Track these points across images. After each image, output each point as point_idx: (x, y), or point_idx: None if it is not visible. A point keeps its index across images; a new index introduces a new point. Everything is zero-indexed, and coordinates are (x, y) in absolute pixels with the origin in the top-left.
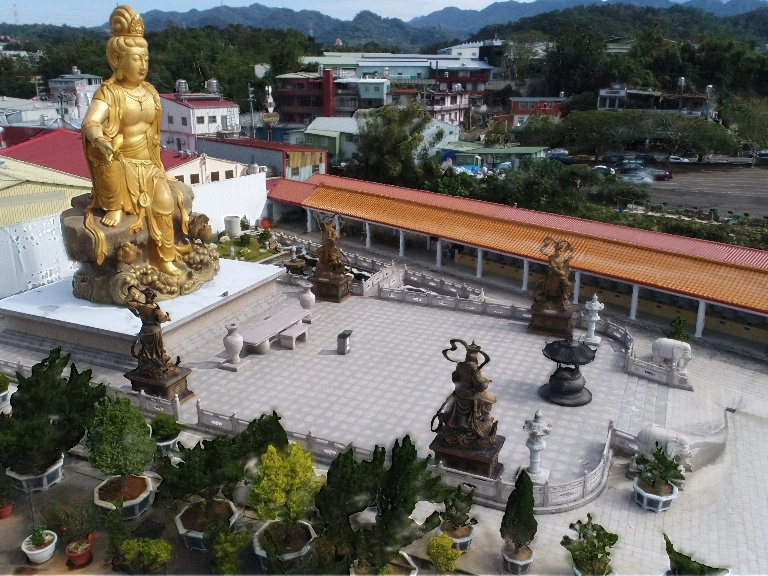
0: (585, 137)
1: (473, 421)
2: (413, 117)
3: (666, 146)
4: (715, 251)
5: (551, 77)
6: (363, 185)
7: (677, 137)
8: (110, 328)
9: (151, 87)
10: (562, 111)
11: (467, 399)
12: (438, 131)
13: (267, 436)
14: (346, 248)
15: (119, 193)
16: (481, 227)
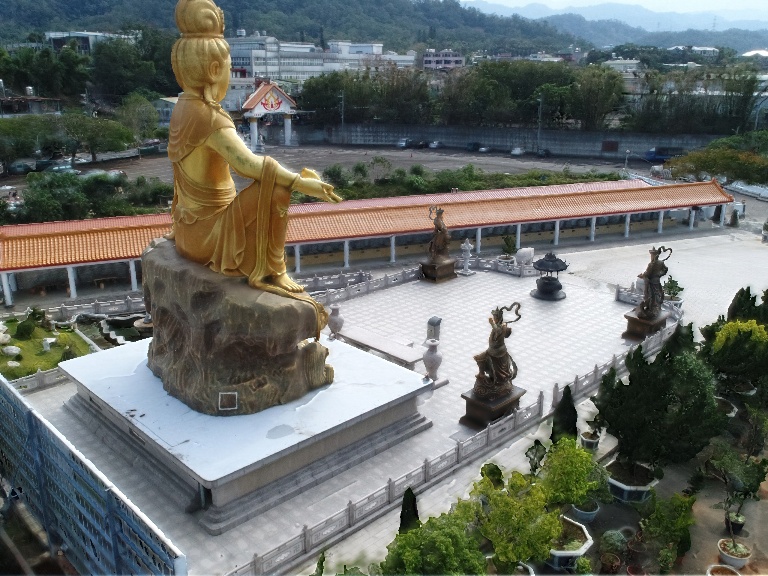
0: (2, 149)
1: (662, 295)
2: None
3: (70, 149)
4: (425, 201)
5: None
6: (10, 231)
7: (77, 139)
8: (396, 395)
9: None
10: None
11: None
12: None
13: None
14: (118, 299)
15: None
16: None
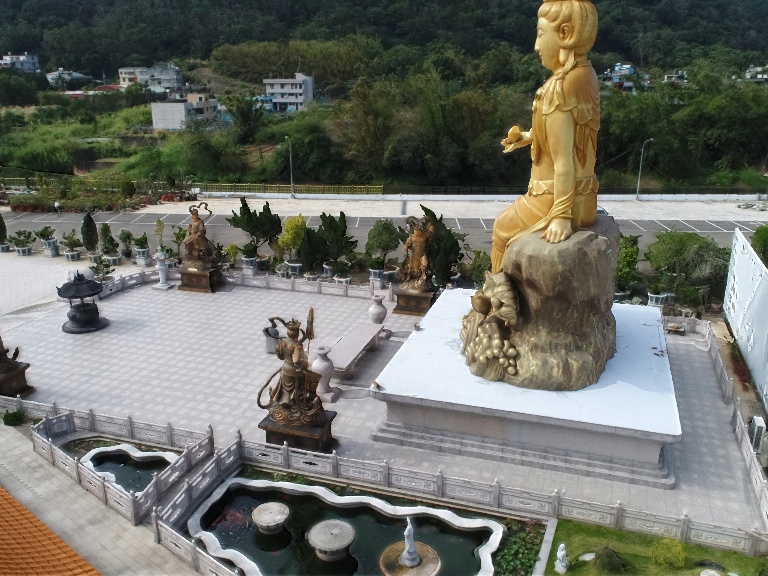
0: None
1: None
2: None
3: None
4: None
5: None
6: None
7: None
8: None
9: None
10: None
11: None
12: None
13: None
14: None
15: None
16: None
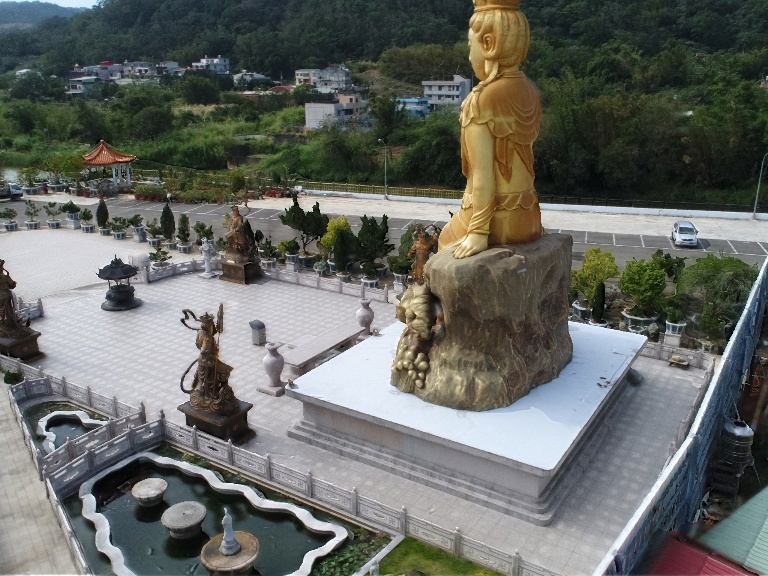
0: None
1: None
2: None
3: None
4: None
5: None
6: None
7: None
8: None
9: (476, 89)
10: None
11: None
12: None
13: None
14: None
15: None
16: None
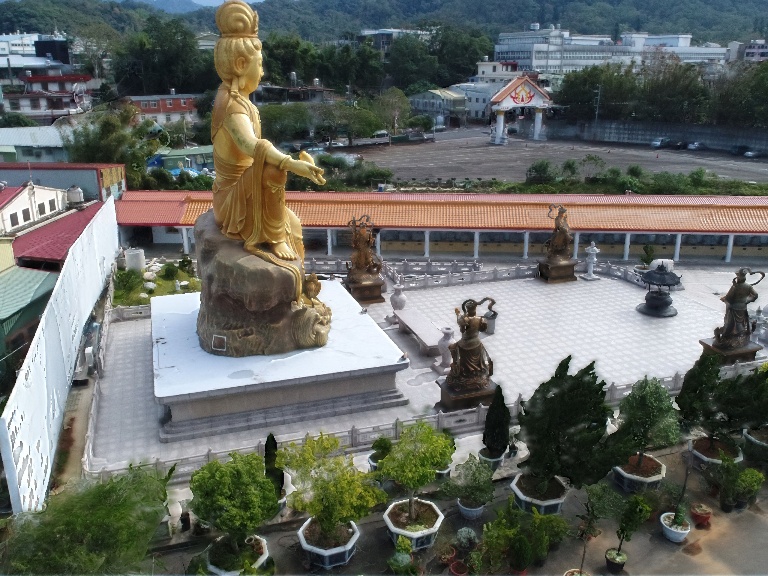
0: (270, 130)
1: (748, 325)
2: (129, 121)
3: (329, 133)
4: (586, 200)
5: (151, 74)
6: (208, 195)
7: (335, 125)
8: (362, 366)
9: None
10: (198, 108)
11: (744, 310)
12: (162, 135)
13: (715, 372)
14: None
15: (284, 221)
16: (420, 212)
